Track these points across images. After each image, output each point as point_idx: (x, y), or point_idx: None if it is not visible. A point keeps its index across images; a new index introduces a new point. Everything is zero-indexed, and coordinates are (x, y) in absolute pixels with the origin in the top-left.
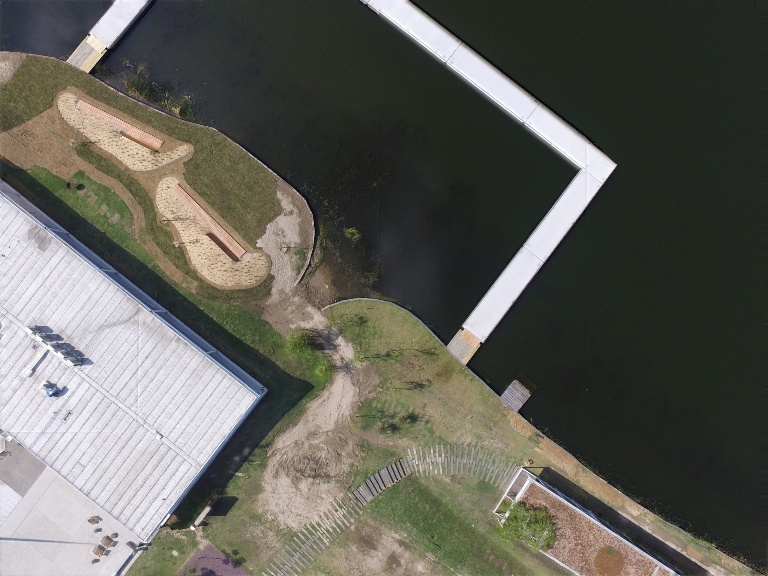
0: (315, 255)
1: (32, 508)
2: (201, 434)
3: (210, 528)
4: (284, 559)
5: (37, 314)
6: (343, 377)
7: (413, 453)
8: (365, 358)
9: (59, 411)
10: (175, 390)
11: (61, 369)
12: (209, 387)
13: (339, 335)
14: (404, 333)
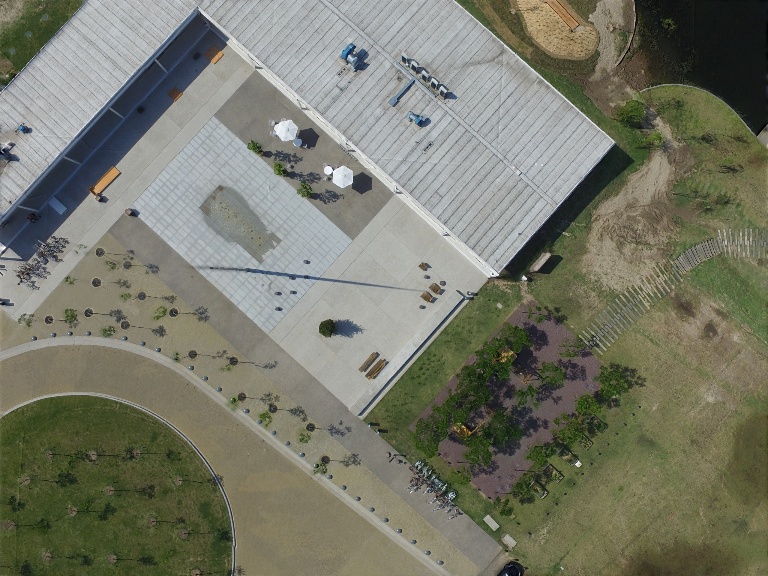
0: (634, 41)
1: (362, 251)
2: (558, 174)
3: (534, 284)
4: (605, 320)
5: (404, 47)
6: (661, 155)
7: (723, 234)
8: (682, 139)
9: (420, 141)
10: (535, 130)
11: (424, 101)
12: (568, 129)
13: (657, 116)
14: (718, 120)
